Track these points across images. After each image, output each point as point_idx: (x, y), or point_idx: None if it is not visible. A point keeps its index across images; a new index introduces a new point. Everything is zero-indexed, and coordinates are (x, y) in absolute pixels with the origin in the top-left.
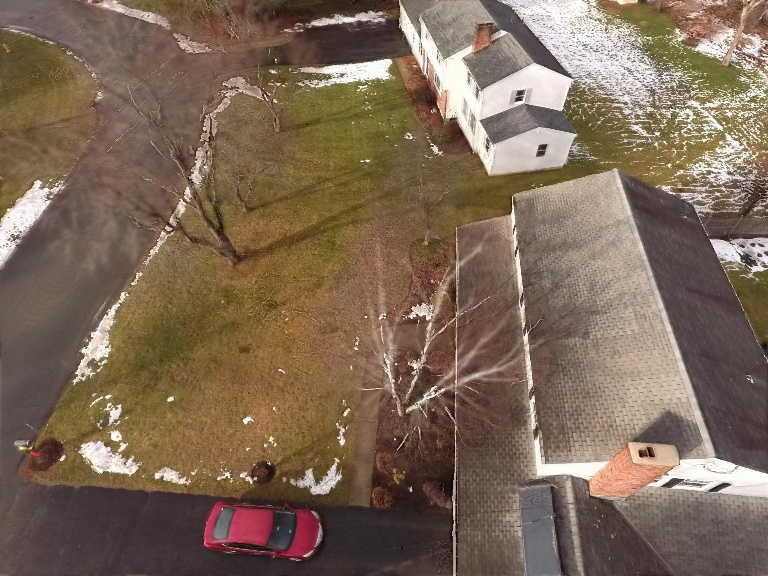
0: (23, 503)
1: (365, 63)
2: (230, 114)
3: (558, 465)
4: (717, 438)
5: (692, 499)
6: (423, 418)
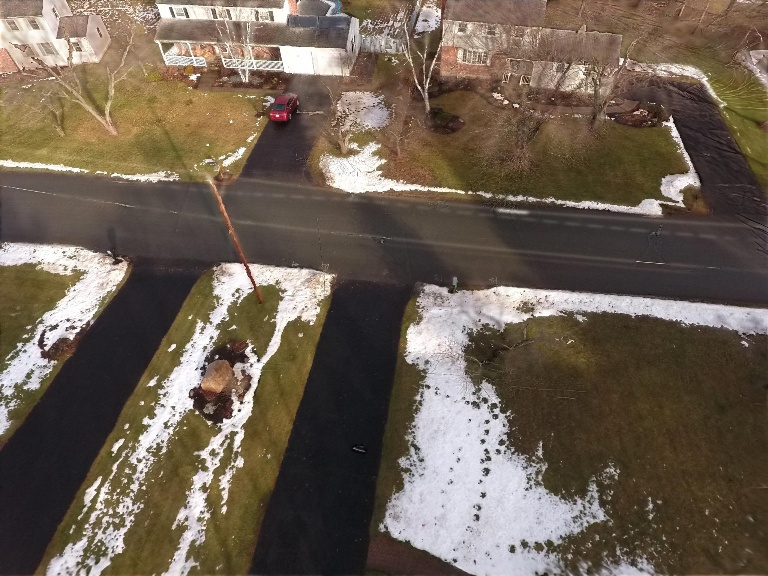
0: None
1: None
2: None
3: (284, 5)
4: None
5: (302, 5)
6: (252, 76)
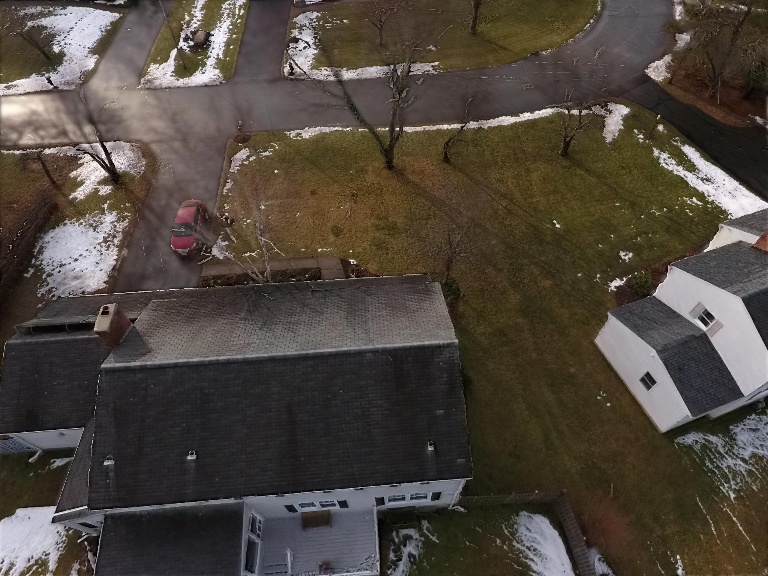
0: (219, 141)
1: (751, 194)
2: (565, 119)
3: None
4: (119, 378)
5: None
6: None
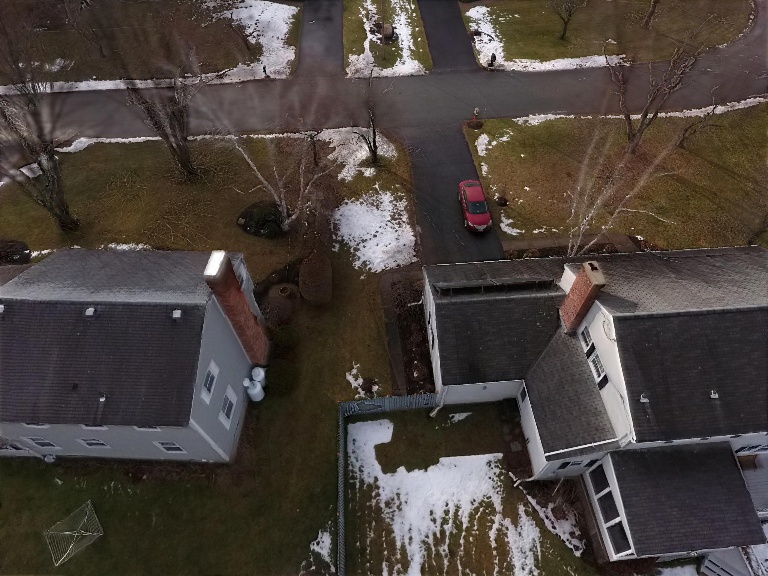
0: (453, 127)
1: None
2: None
3: None
4: (630, 326)
5: (586, 376)
6: None
